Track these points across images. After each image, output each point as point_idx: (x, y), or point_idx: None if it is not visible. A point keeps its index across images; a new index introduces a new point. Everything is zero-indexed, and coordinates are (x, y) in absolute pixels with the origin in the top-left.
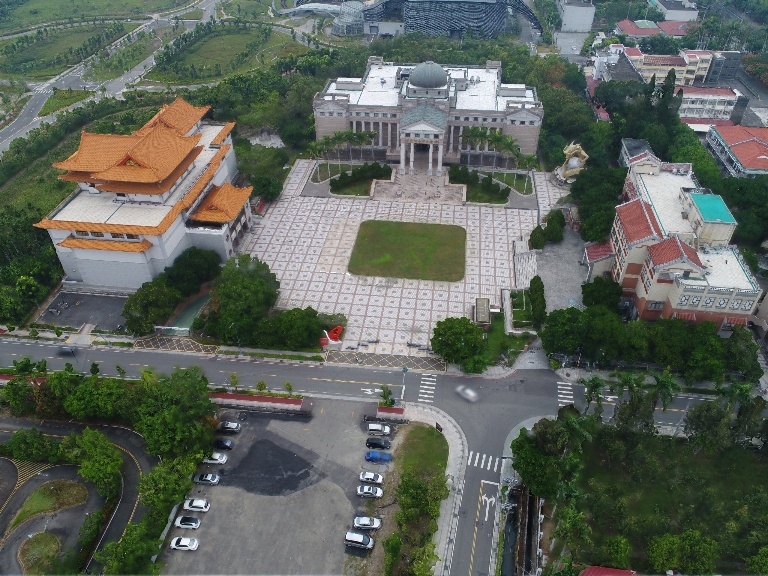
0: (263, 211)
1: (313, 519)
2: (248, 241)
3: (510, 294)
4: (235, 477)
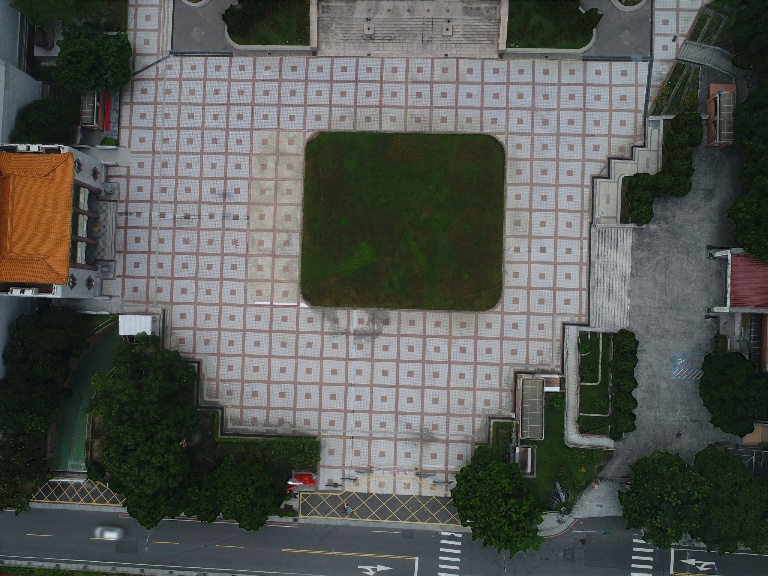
0: (112, 121)
1: None
2: (111, 226)
3: (578, 345)
4: None
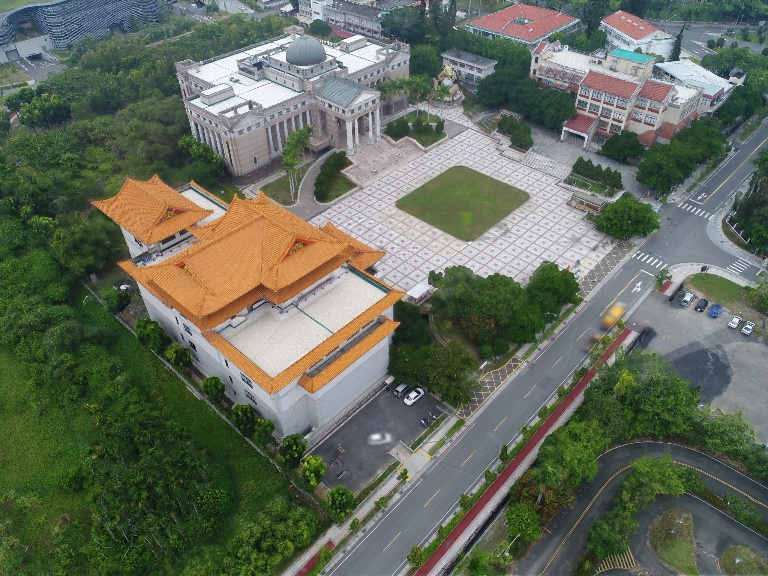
0: None
1: (763, 367)
2: None
3: (569, 182)
4: (701, 397)
